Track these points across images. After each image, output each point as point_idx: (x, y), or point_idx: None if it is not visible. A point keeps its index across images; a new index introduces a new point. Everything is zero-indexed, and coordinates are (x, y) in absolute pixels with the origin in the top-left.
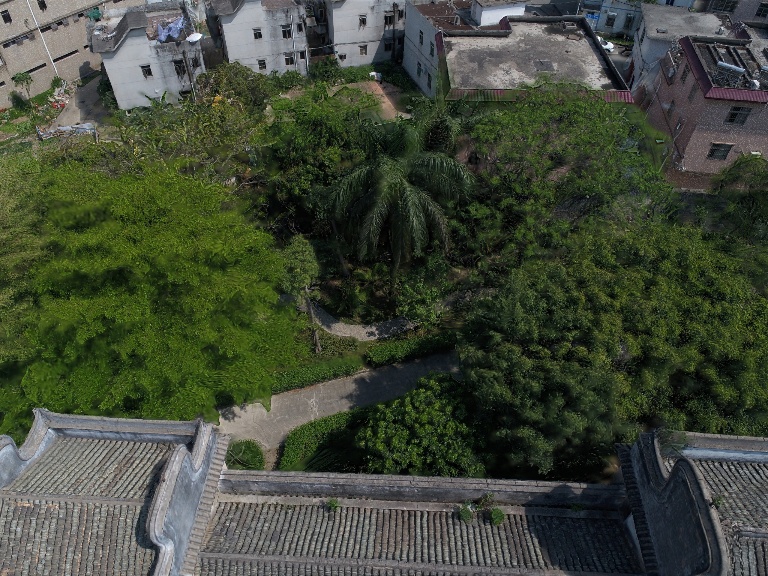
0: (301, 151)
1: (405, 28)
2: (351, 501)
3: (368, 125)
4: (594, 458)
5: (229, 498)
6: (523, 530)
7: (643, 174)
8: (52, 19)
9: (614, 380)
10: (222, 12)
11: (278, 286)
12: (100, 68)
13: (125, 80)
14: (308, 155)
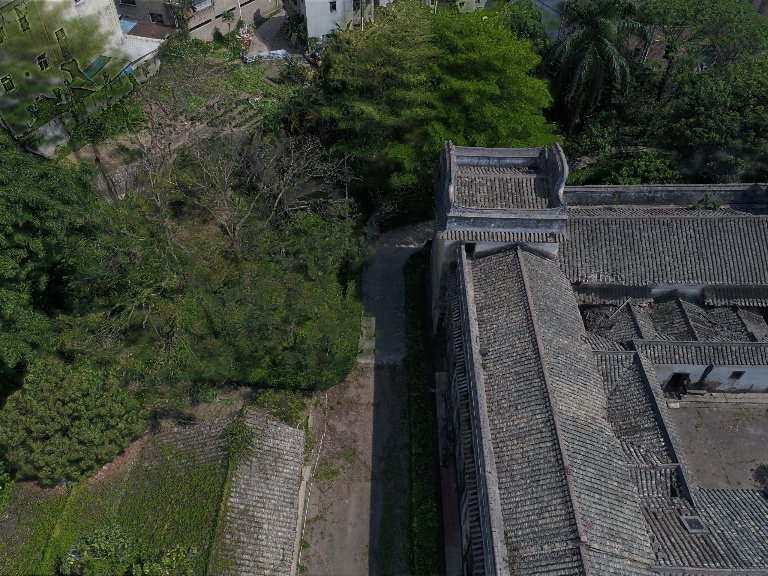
0: None
1: None
2: (622, 206)
3: (575, 6)
4: (765, 179)
5: None
6: (733, 211)
7: (762, 32)
8: None
9: None
10: None
11: None
12: (266, 15)
13: (317, 13)
14: None
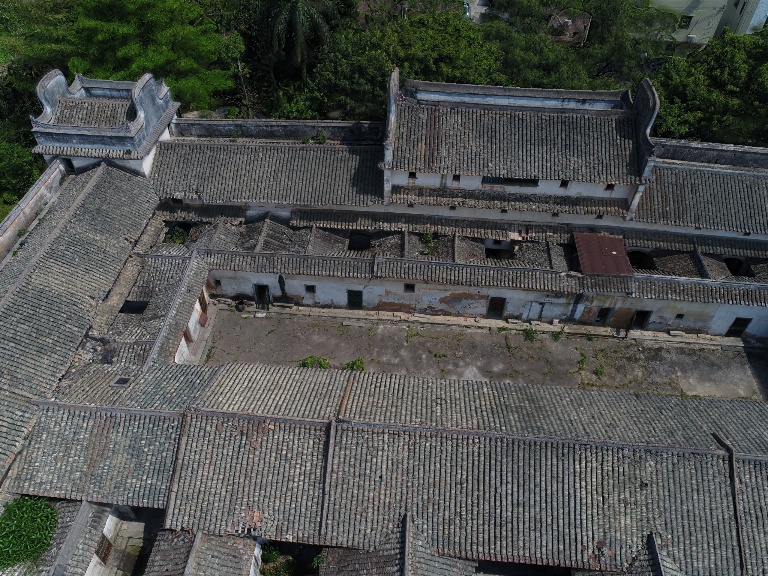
0: (247, 5)
1: None
2: (246, 139)
3: None
4: (383, 120)
5: (179, 138)
6: None
7: None
8: None
9: (383, 60)
10: None
11: (219, 57)
12: None
13: None
14: (251, 5)
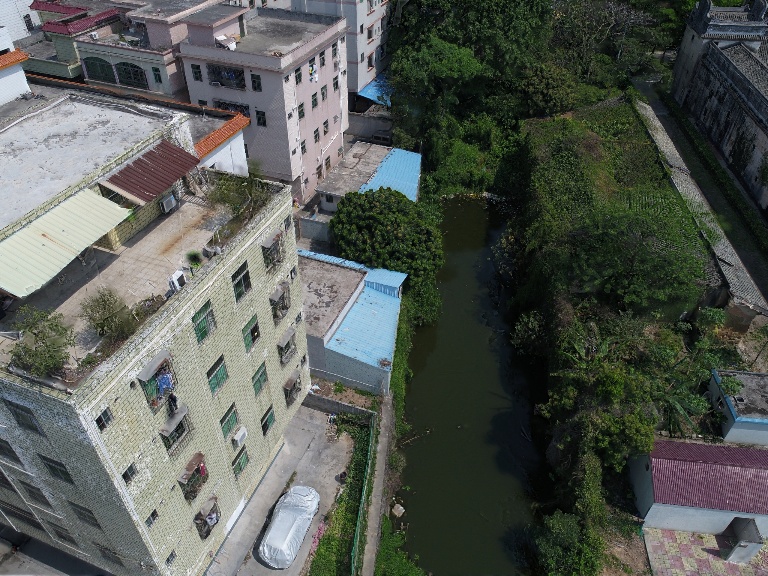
0: None
1: None
2: None
3: None
4: None
5: None
6: None
7: None
8: None
9: None
10: None
11: None
12: None
13: None
14: None
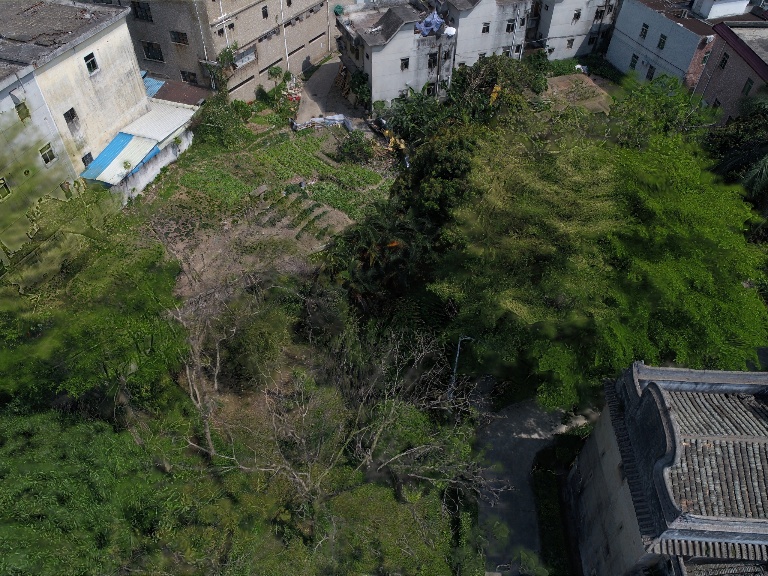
0: (634, 136)
1: (617, 22)
2: None
3: None
4: None
5: None
6: None
7: None
8: (293, 15)
9: None
10: (463, 7)
11: None
12: (316, 63)
13: (384, 72)
14: None
